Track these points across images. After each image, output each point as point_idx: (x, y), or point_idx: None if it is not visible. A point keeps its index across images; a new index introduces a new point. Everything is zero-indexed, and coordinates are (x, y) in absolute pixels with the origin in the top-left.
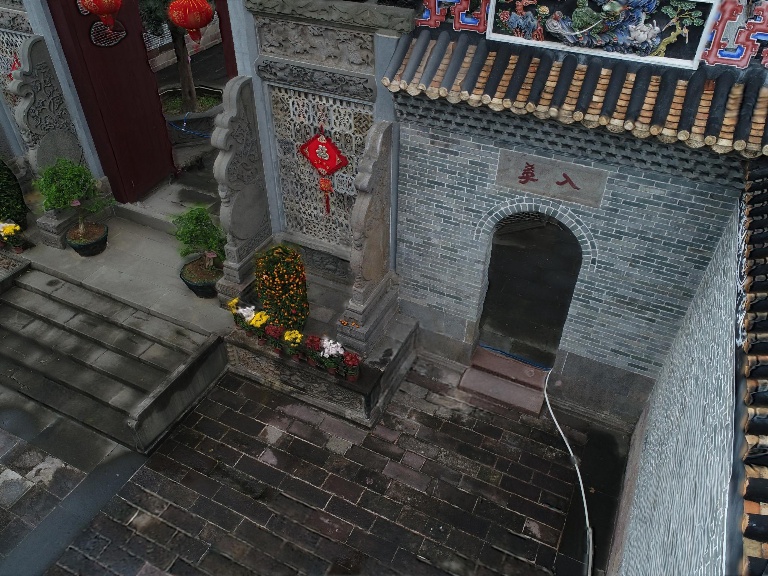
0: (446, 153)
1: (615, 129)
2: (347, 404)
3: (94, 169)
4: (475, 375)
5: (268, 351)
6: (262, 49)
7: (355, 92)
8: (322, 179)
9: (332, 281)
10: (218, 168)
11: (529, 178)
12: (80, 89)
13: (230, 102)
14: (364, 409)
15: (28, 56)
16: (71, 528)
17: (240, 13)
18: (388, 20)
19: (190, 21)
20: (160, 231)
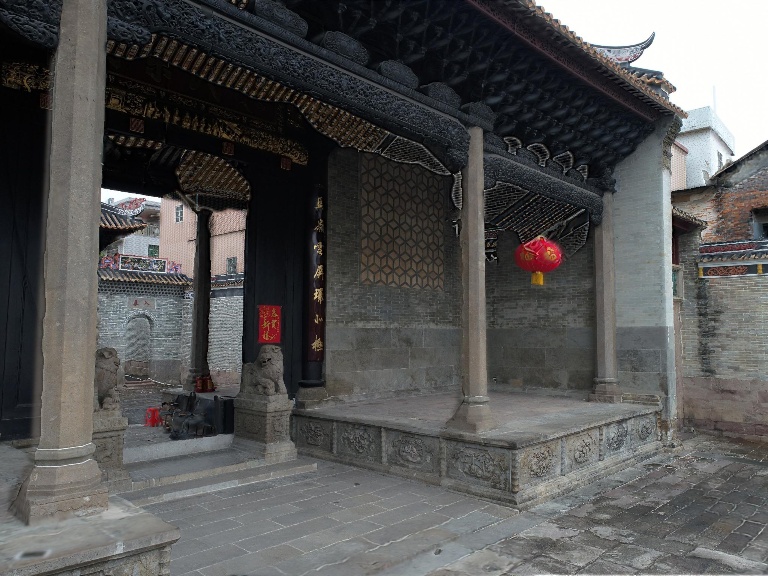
0: (111, 301)
1: (160, 282)
2: None
3: None
4: None
5: None
6: None
7: None
8: None
9: None
10: None
11: (136, 304)
12: None
13: None
14: None
15: None
16: None
17: None
18: None
19: None
20: None
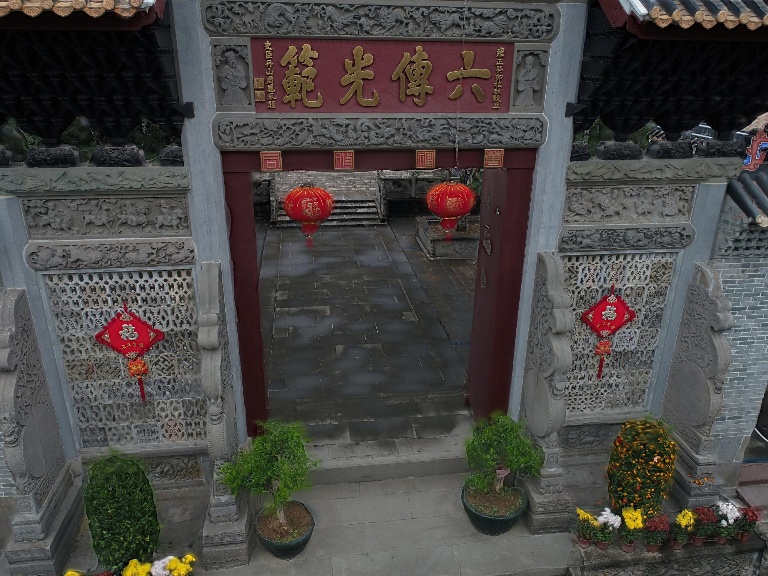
0: (754, 278)
1: None
2: (733, 573)
3: (240, 432)
4: (749, 491)
5: (643, 554)
6: (564, 220)
7: (670, 242)
8: (602, 342)
9: (590, 455)
10: (562, 355)
11: None
12: (246, 324)
13: (558, 279)
14: (753, 569)
15: (218, 291)
16: None
17: (559, 186)
18: (722, 169)
19: (466, 207)
20: (338, 484)
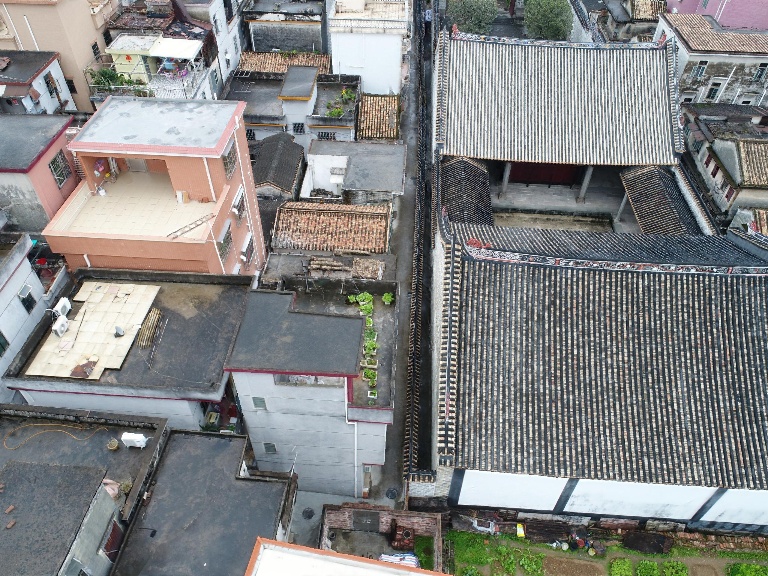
0: None
1: None
2: None
3: None
4: None
5: None
6: None
7: None
8: None
9: None
10: None
11: None
12: None
13: None
14: None
15: None
16: None
17: None
18: None
19: None
20: None
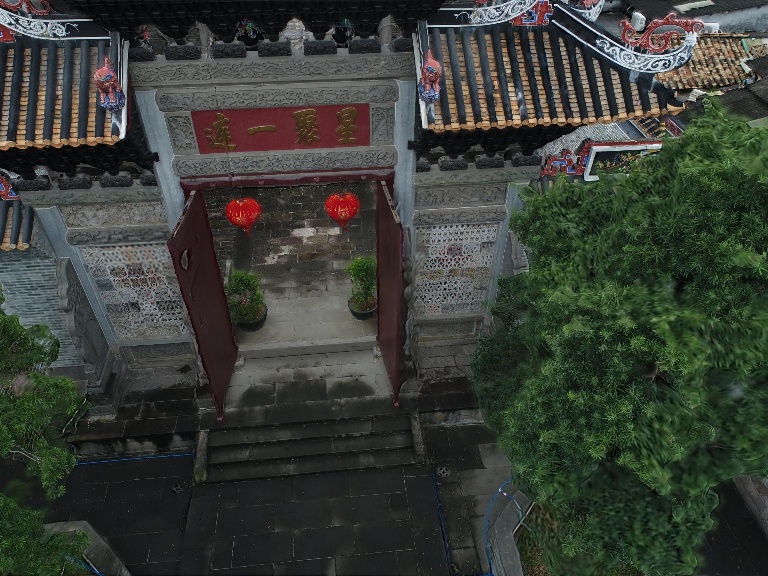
0: None
1: None
2: None
3: None
4: None
5: None
6: None
7: None
8: None
9: None
10: None
11: None
12: None
13: None
14: None
15: None
16: (238, 253)
17: None
18: None
19: None
20: None
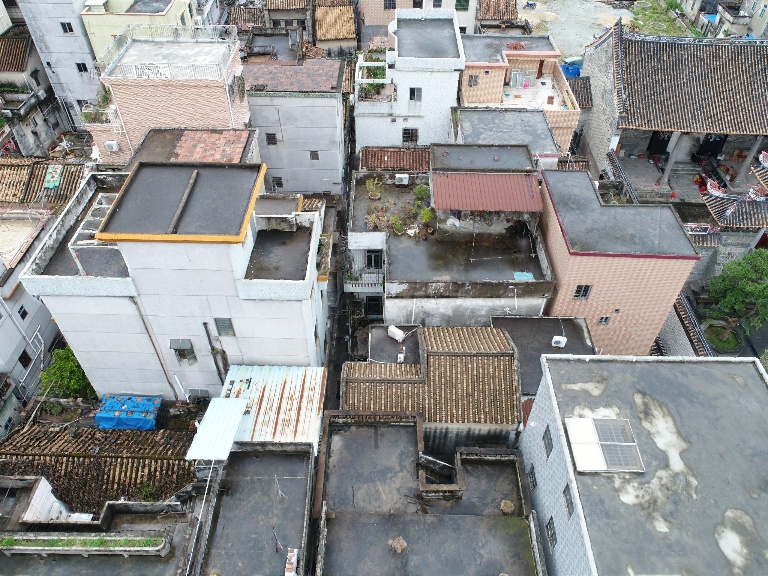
0: None
1: None
2: None
3: None
4: None
5: None
6: None
7: None
8: None
9: None
10: None
11: None
12: None
13: None
14: None
15: None
16: None
17: None
18: None
19: None
20: None
